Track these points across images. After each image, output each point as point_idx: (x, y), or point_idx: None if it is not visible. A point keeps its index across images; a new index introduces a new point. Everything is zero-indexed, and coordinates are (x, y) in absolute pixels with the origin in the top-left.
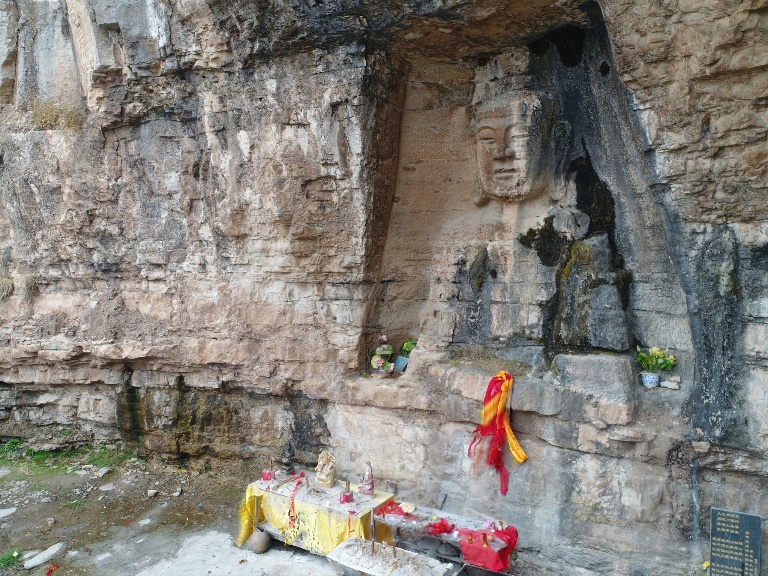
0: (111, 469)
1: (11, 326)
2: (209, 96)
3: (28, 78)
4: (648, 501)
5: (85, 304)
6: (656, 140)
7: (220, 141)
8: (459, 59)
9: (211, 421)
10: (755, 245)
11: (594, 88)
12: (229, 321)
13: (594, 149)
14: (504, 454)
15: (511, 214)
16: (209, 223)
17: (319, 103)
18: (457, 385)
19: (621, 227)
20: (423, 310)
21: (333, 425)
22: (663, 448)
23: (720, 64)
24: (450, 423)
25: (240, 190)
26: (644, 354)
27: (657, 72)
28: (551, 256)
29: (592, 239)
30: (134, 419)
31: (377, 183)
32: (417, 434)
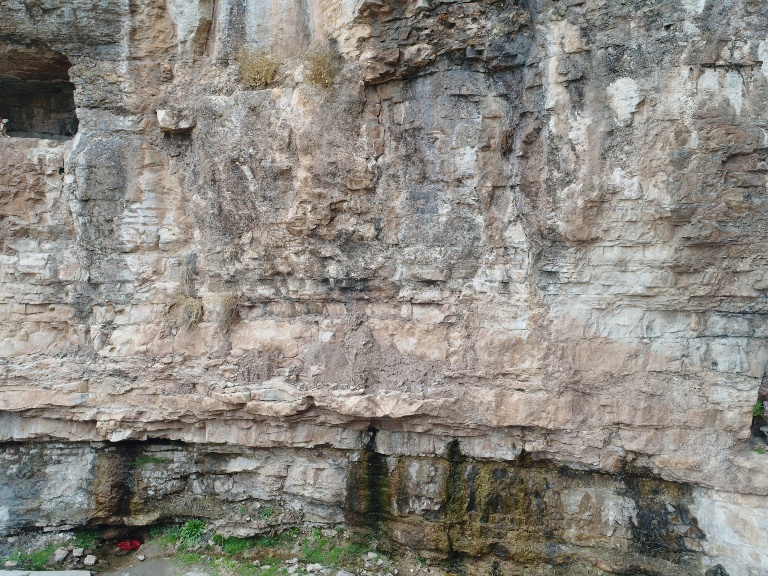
0: (353, 574)
1: (202, 365)
2: (558, 28)
3: (233, 19)
4: None
5: (309, 335)
6: None
7: (571, 97)
8: None
9: (498, 506)
10: None
11: None
12: (546, 365)
13: None
14: None
15: None
16: (526, 221)
17: None
18: None
19: None
20: None
21: (709, 522)
22: None
23: None
24: None
25: (603, 171)
26: None
27: None
28: None
29: None
30: (375, 498)
31: None
32: None
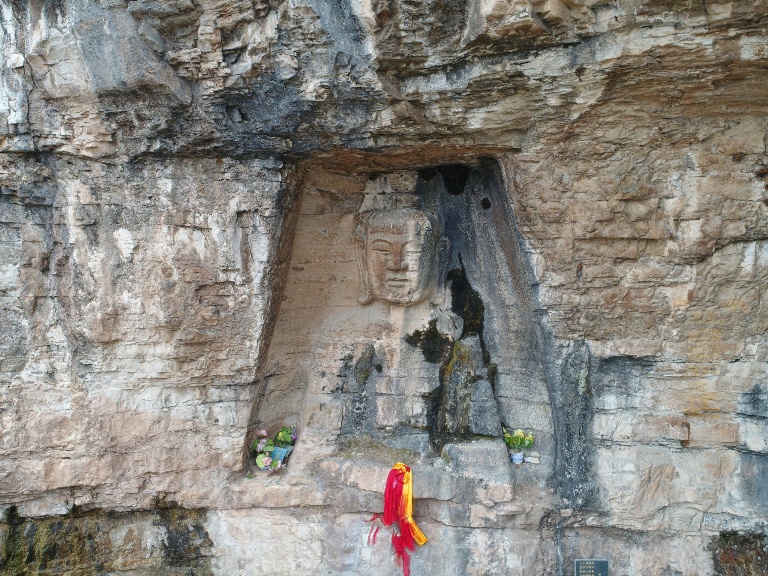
0: None
1: None
2: (75, 185)
3: None
4: (527, 561)
5: None
6: (542, 277)
7: (88, 236)
8: (354, 173)
9: (55, 553)
10: (602, 357)
11: (474, 216)
12: (87, 436)
13: (469, 264)
14: (405, 539)
15: (398, 316)
16: (63, 326)
17: (223, 210)
18: (354, 478)
19: (488, 329)
20: (308, 404)
21: (216, 533)
22: (537, 516)
23: (597, 232)
24: (345, 514)
25: (115, 293)
26: (509, 434)
27: (550, 229)
28: (434, 354)
29: (468, 340)
30: None
31: (275, 287)
32: (312, 530)
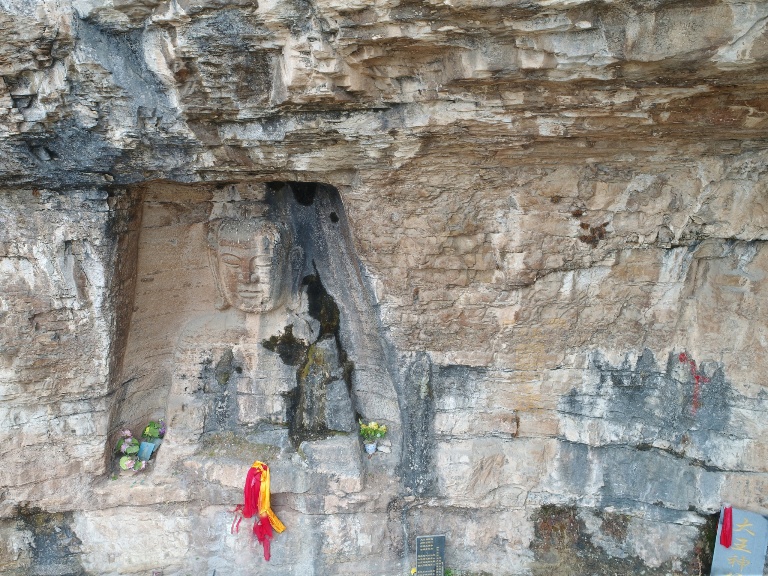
0: None
1: None
2: None
3: None
4: (376, 540)
5: None
6: (382, 300)
7: None
8: None
9: None
10: (442, 365)
11: (324, 227)
12: None
13: (323, 271)
14: (265, 528)
15: (254, 322)
16: None
17: (49, 240)
18: (216, 476)
19: (344, 330)
20: (170, 406)
21: (83, 533)
22: (385, 502)
23: (428, 264)
24: (210, 506)
25: None
26: (364, 426)
27: (385, 259)
28: (291, 358)
29: (324, 342)
30: None
31: (119, 306)
32: (179, 523)
